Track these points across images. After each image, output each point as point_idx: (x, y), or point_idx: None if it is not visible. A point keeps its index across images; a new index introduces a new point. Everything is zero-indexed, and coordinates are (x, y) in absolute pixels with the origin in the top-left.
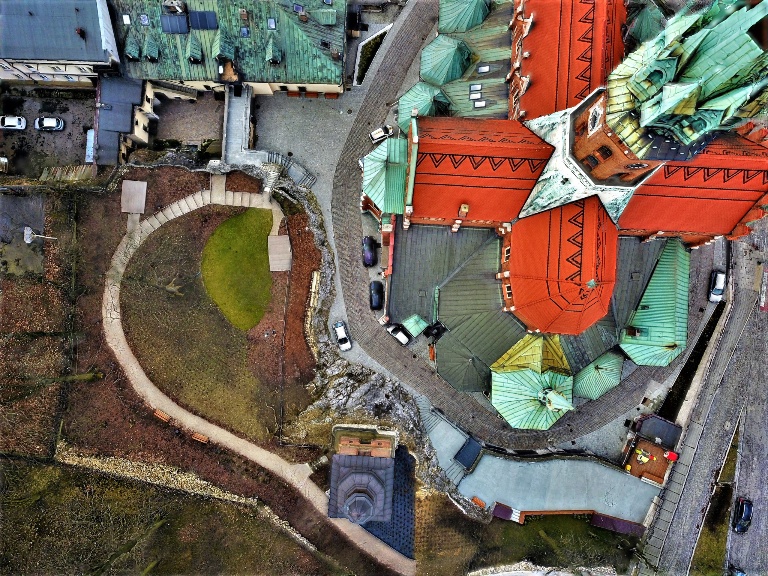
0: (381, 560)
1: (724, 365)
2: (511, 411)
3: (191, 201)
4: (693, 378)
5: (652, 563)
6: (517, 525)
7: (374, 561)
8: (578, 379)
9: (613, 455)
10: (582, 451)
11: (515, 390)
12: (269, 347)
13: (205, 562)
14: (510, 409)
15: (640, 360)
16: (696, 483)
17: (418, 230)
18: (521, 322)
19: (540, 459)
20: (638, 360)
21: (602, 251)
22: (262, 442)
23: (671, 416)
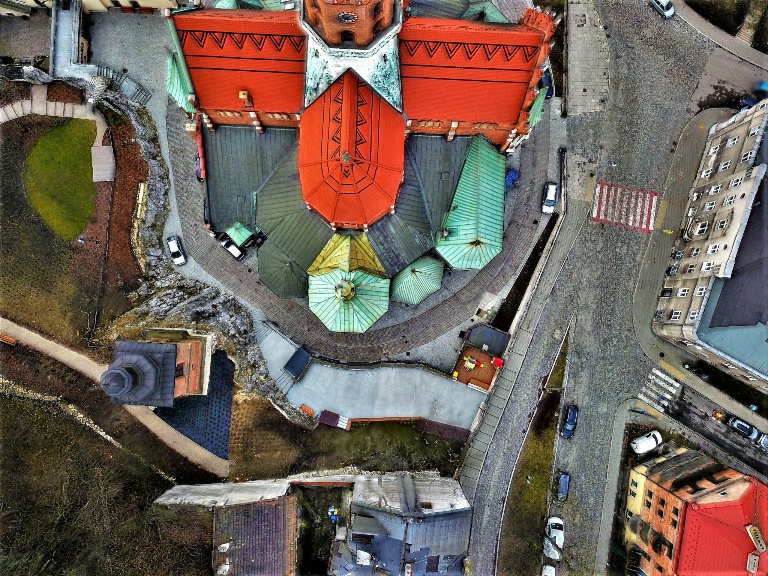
0: (191, 459)
1: (555, 275)
2: (325, 313)
3: (10, 111)
4: (526, 289)
5: (476, 466)
6: (344, 432)
7: (183, 460)
8: (397, 283)
9: (447, 366)
10: (415, 361)
11: (324, 290)
12: (92, 257)
13: (2, 458)
14: (324, 311)
15: (455, 262)
16: (523, 389)
17: (226, 131)
18: (327, 221)
19: (367, 367)
20: (453, 262)
21: (371, 131)
22: (70, 344)
23: (505, 326)
